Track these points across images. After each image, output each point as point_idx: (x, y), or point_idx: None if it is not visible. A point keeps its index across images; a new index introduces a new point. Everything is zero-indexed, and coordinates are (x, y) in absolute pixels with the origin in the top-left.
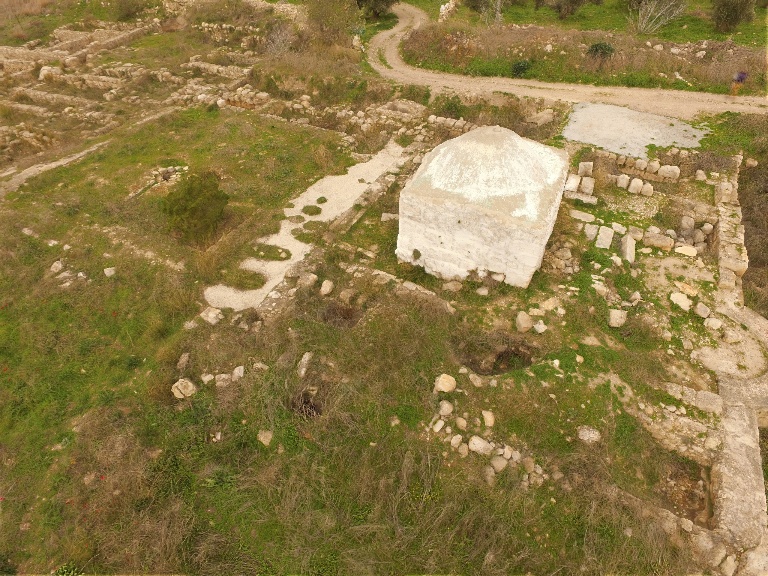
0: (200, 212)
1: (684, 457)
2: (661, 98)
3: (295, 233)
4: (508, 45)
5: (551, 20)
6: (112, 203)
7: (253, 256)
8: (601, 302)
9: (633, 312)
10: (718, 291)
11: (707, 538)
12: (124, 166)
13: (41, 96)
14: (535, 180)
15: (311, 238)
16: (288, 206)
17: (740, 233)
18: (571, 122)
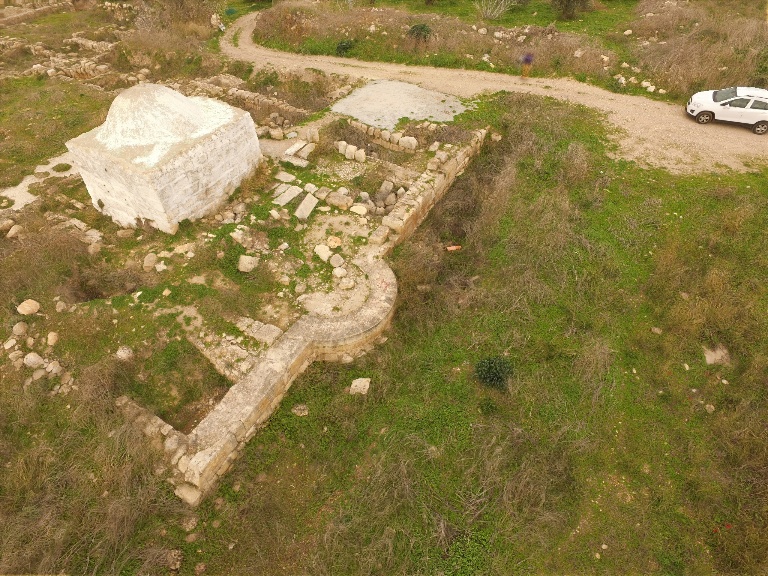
0: None
1: None
2: (458, 78)
3: (31, 186)
4: (337, 25)
5: (419, 5)
6: None
7: None
8: (236, 249)
9: (263, 259)
10: (367, 246)
11: (174, 440)
12: None
13: None
14: (174, 133)
15: (39, 190)
16: (43, 163)
17: (420, 196)
18: (349, 96)
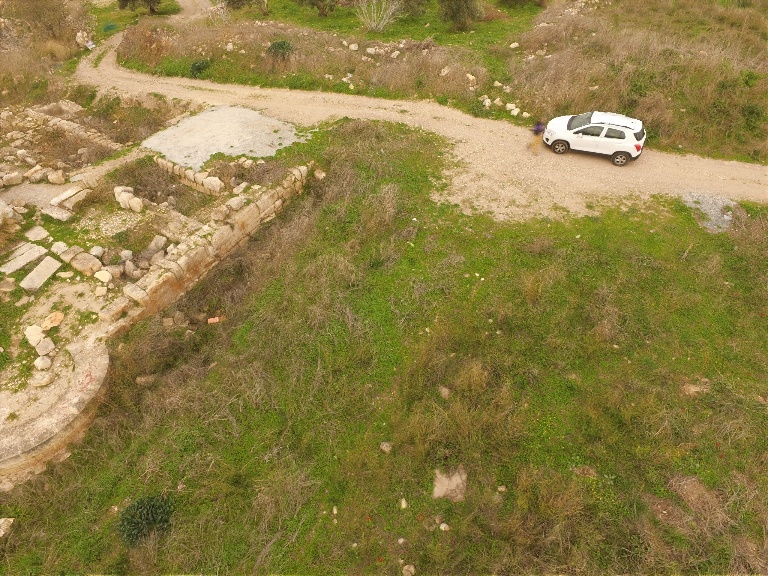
0: None
1: None
2: (310, 101)
3: None
4: (195, 43)
5: (312, 17)
6: None
7: None
8: None
9: None
10: (95, 324)
11: None
12: None
13: None
14: None
15: None
16: None
17: (184, 256)
18: (172, 127)
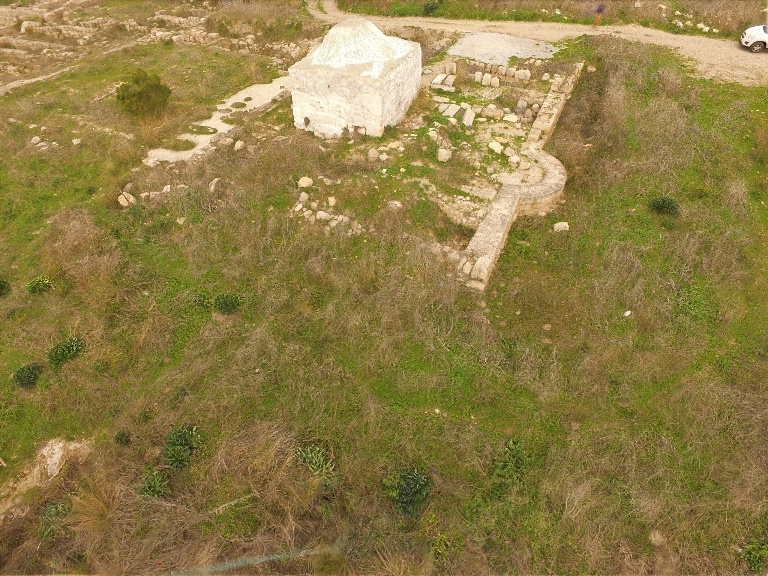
0: (146, 98)
1: (465, 226)
2: (539, 28)
3: (223, 119)
4: None
5: None
6: (80, 102)
7: (188, 132)
8: (433, 145)
9: (456, 151)
10: (526, 142)
11: (456, 254)
12: (91, 81)
13: (23, 43)
14: (383, 55)
15: (234, 120)
16: (220, 103)
17: (555, 108)
18: (457, 44)
